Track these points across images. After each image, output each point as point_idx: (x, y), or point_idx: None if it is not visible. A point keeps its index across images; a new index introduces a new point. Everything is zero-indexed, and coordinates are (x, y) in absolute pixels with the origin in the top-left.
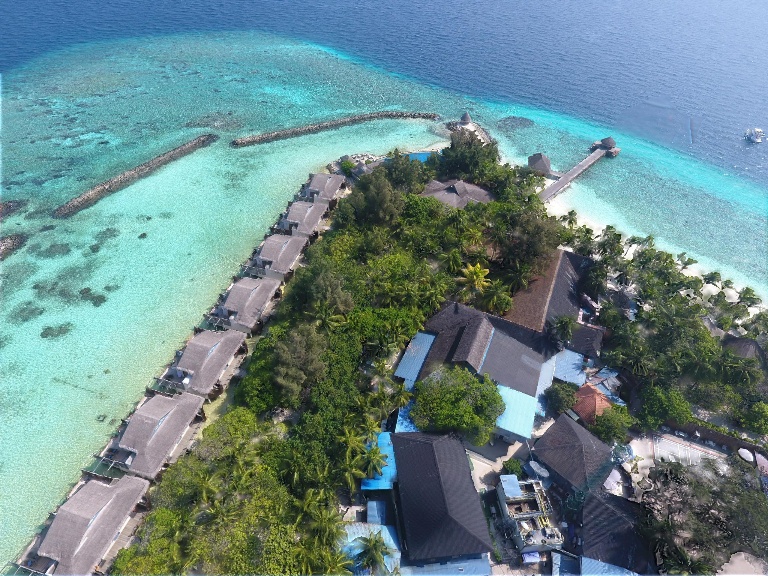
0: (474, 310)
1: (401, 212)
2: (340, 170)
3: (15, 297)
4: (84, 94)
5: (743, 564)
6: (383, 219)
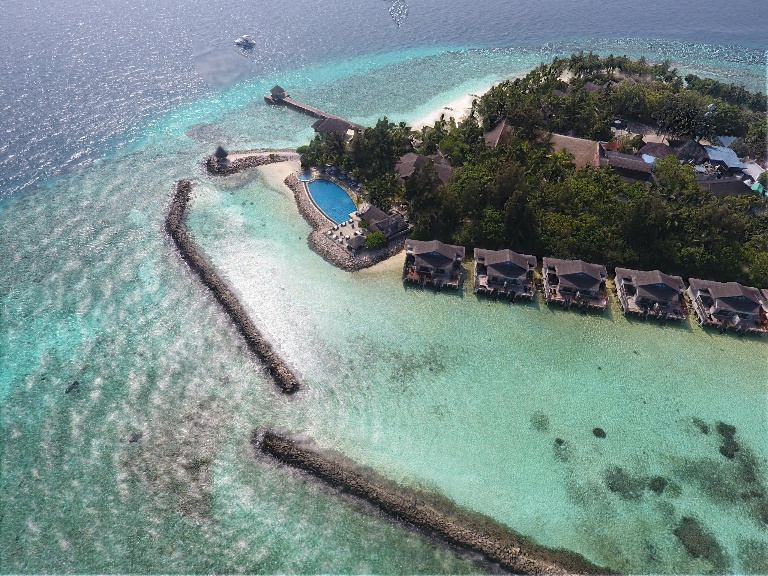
0: None
1: None
2: (371, 253)
3: None
4: None
5: (655, 136)
6: None
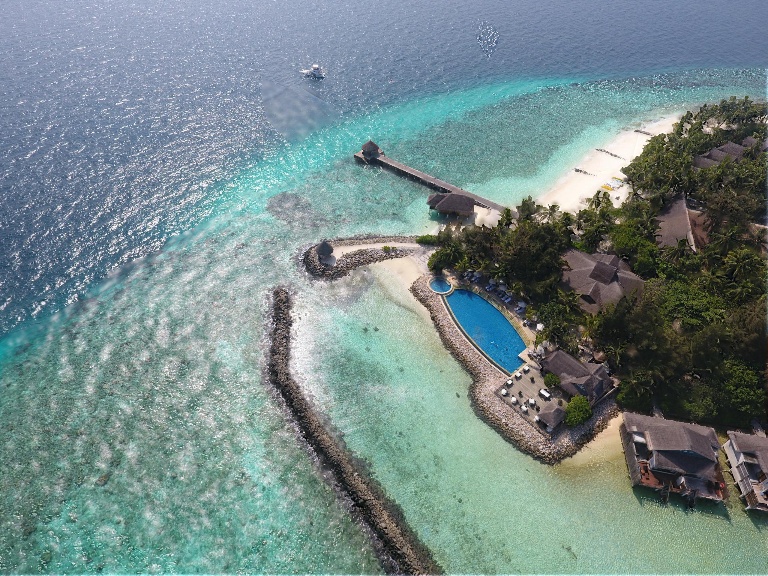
0: None
1: None
2: (573, 432)
3: None
4: None
5: None
6: None
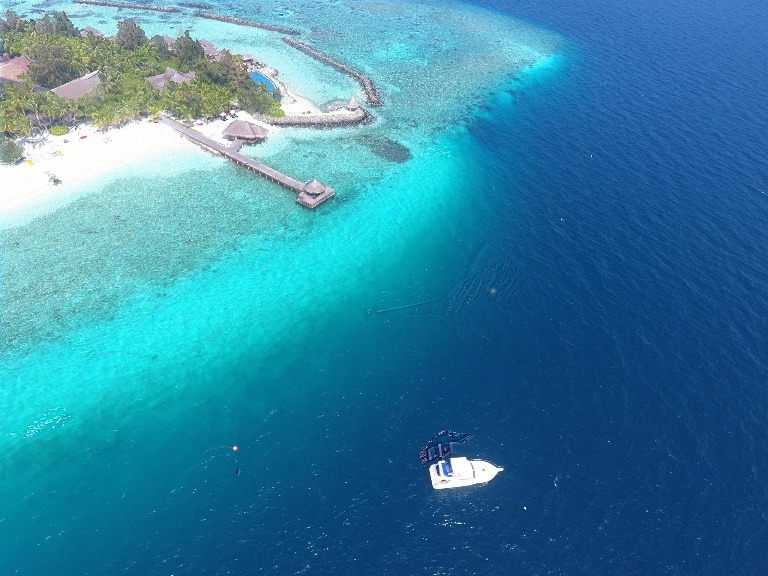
0: (13, 59)
1: (124, 45)
2: None
3: None
4: None
5: None
6: None
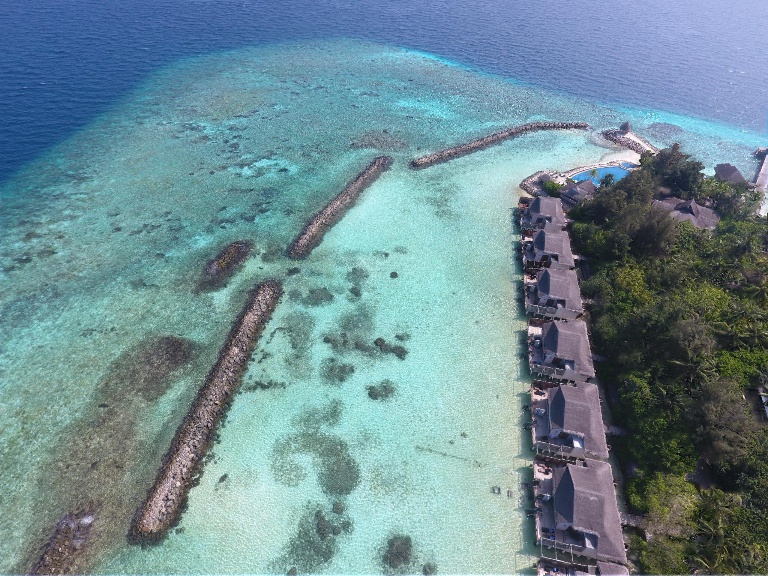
0: None
1: None
2: (541, 191)
3: (313, 353)
4: (227, 116)
5: None
6: (661, 249)
